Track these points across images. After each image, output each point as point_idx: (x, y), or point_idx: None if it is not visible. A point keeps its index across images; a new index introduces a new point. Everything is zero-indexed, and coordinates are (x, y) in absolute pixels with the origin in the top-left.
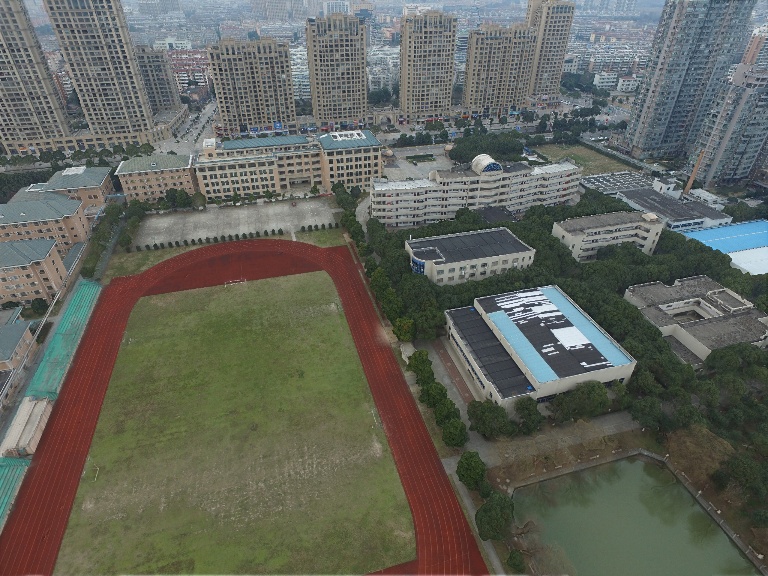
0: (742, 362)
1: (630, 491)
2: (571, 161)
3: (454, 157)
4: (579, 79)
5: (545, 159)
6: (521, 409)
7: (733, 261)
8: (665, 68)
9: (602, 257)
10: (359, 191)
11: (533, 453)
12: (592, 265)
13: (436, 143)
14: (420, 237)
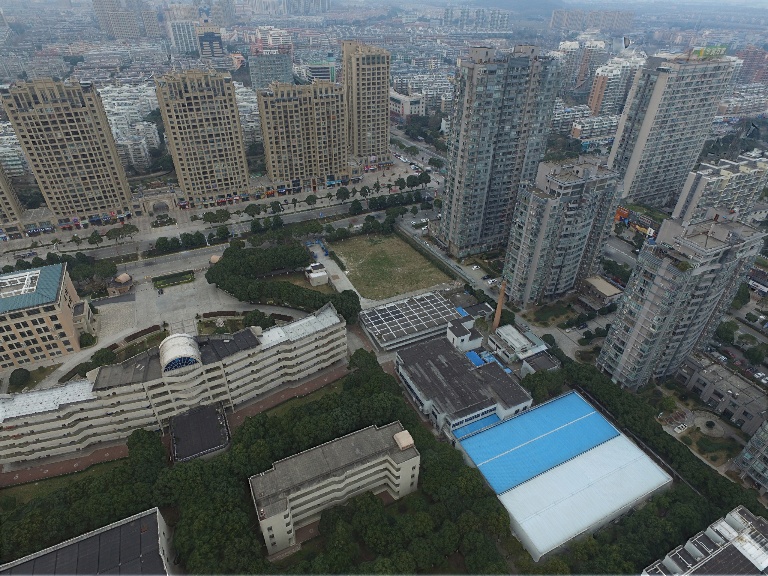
0: None
1: None
2: (333, 309)
3: (211, 281)
4: (427, 122)
5: (342, 267)
6: None
7: (516, 513)
8: (466, 156)
9: (323, 532)
10: (22, 377)
11: None
12: None
13: (212, 244)
14: (1, 547)
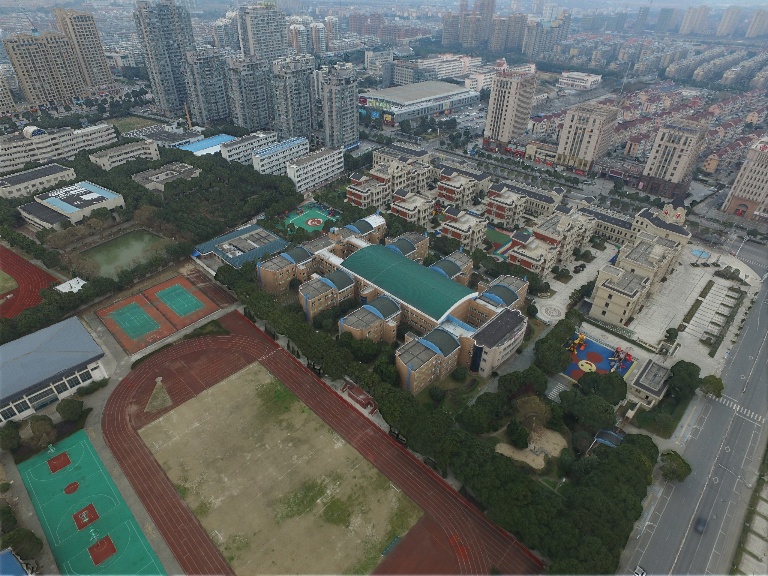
0: (176, 185)
1: (139, 249)
2: (104, 122)
3: None
4: (139, 71)
5: None
6: (62, 225)
7: (197, 154)
8: (154, 57)
9: None
10: None
11: (65, 233)
12: (111, 169)
13: (8, 133)
14: None
